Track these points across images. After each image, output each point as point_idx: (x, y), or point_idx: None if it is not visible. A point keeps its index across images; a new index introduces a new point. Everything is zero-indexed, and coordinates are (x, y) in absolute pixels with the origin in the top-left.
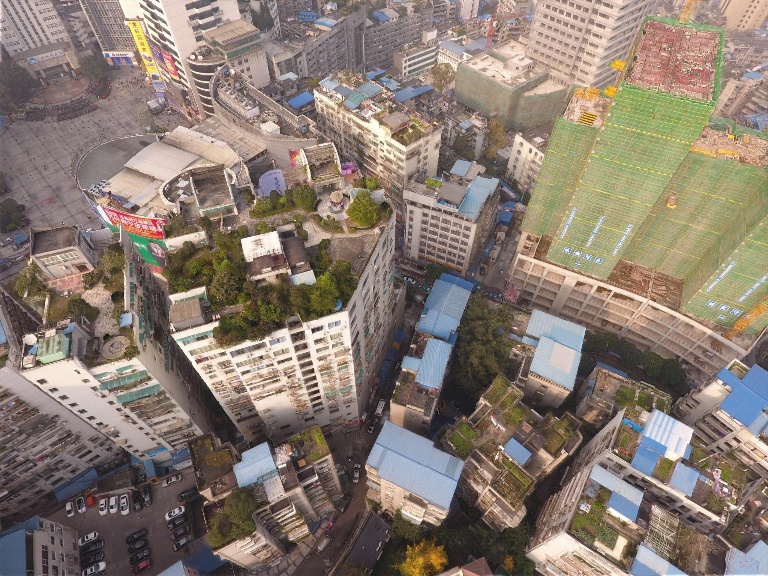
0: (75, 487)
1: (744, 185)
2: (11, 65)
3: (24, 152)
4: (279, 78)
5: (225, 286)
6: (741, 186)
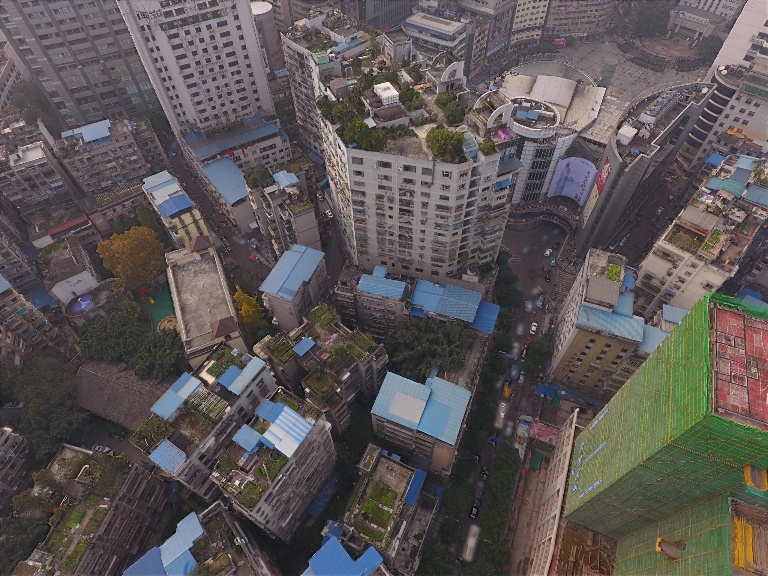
0: (315, 158)
1: None
2: (664, 8)
3: (581, 58)
4: (756, 139)
5: (355, 90)
6: None
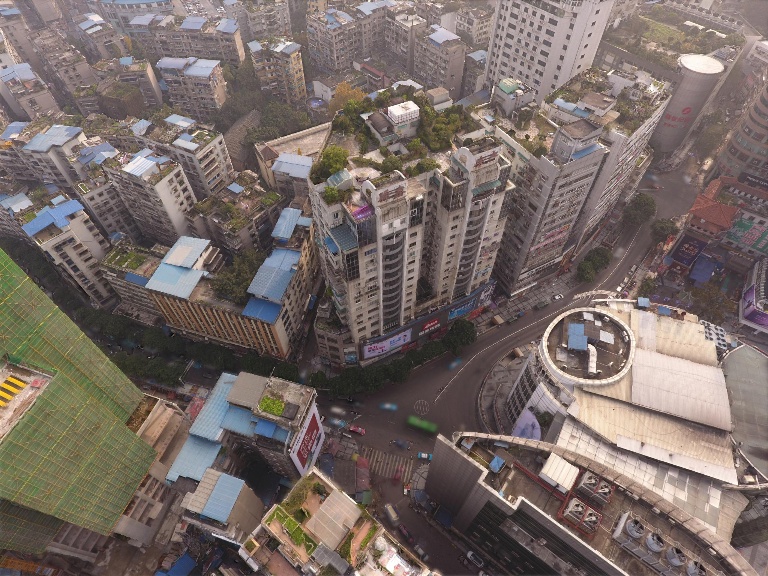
0: None
1: None
2: None
3: None
4: None
5: None
6: None
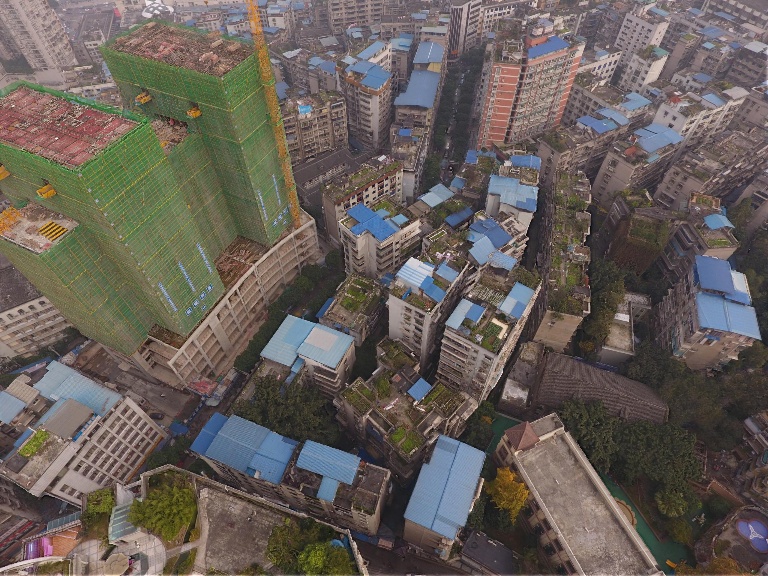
0: None
1: (197, 152)
2: None
3: None
4: None
5: None
6: (197, 154)
